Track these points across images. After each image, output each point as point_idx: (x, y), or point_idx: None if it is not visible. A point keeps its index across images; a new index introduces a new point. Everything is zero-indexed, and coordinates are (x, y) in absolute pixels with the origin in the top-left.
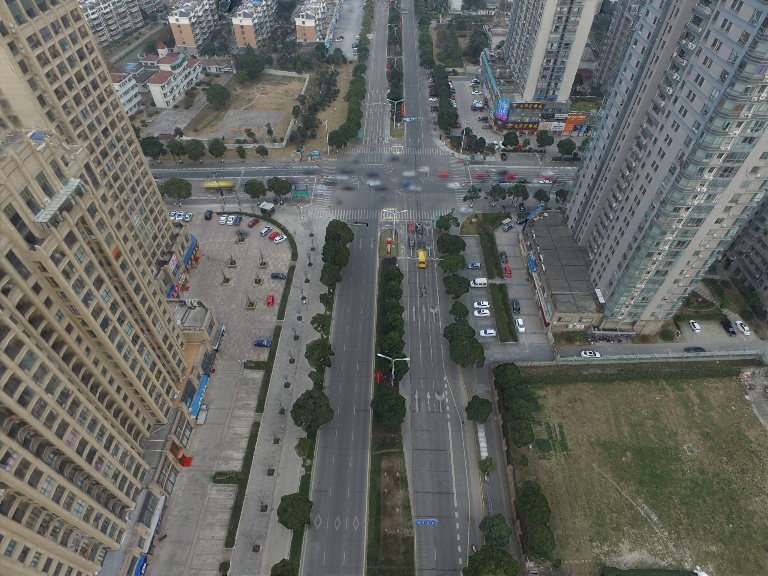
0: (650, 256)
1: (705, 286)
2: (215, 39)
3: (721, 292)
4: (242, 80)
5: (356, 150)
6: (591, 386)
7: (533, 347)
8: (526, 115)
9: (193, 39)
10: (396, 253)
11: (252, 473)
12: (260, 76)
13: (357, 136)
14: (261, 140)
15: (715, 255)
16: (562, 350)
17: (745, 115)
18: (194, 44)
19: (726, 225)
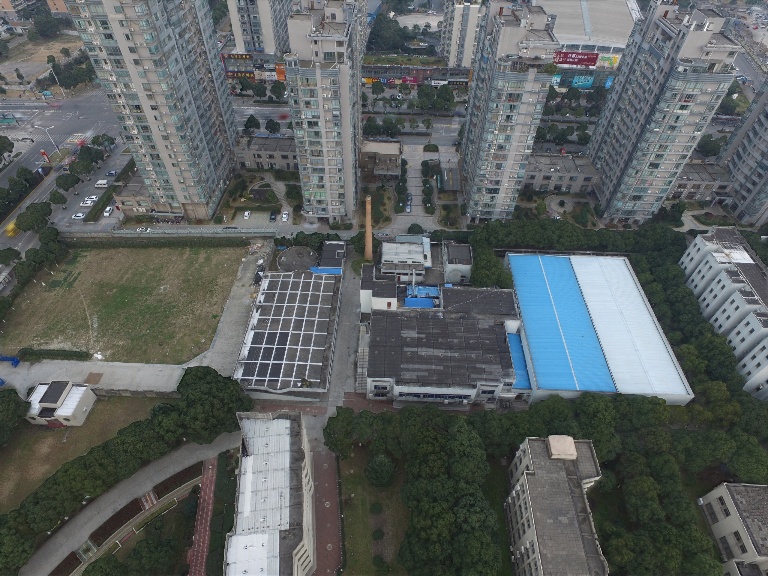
0: (130, 140)
1: (285, 189)
2: (41, 6)
3: (291, 193)
4: (31, 37)
5: (92, 93)
6: (128, 250)
7: (106, 226)
8: (241, 65)
9: (10, 4)
10: (56, 164)
11: None
12: (58, 36)
13: (95, 81)
14: (14, 83)
15: (183, 140)
16: (127, 228)
17: (84, 15)
18: (12, 9)
19: (166, 112)
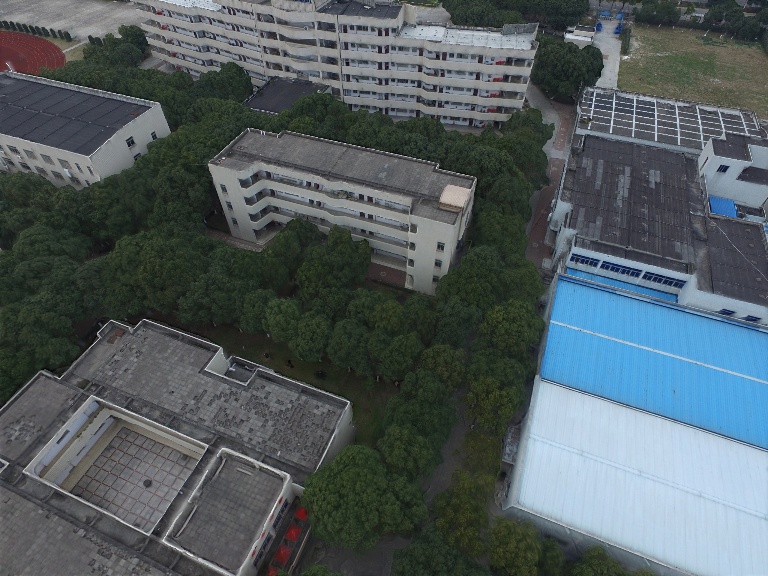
0: None
1: None
2: None
3: None
4: None
5: None
6: None
7: None
8: None
9: None
10: None
11: None
12: None
13: None
14: None
15: None
16: None
17: None
18: None
19: None
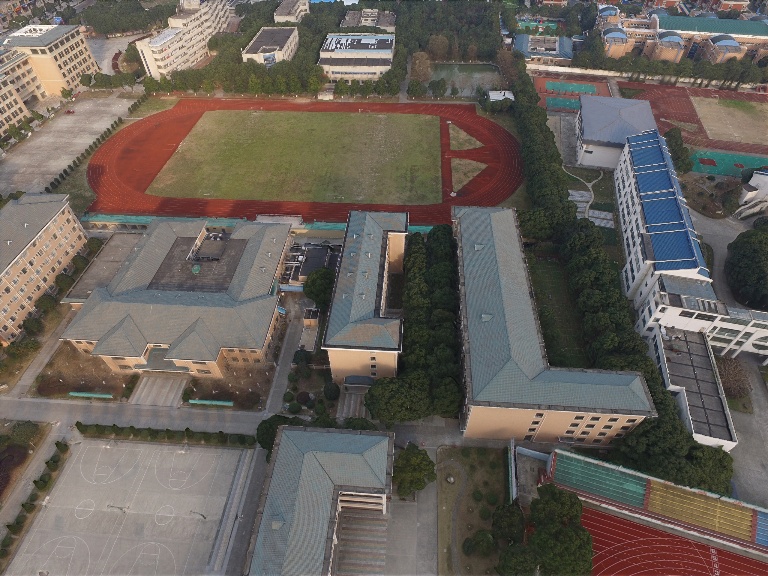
0: None
1: None
2: None
3: None
4: None
5: None
6: None
7: None
8: None
9: None
10: None
11: (62, 4)
12: None
13: None
14: None
15: None
16: None
17: None
18: None
19: None
